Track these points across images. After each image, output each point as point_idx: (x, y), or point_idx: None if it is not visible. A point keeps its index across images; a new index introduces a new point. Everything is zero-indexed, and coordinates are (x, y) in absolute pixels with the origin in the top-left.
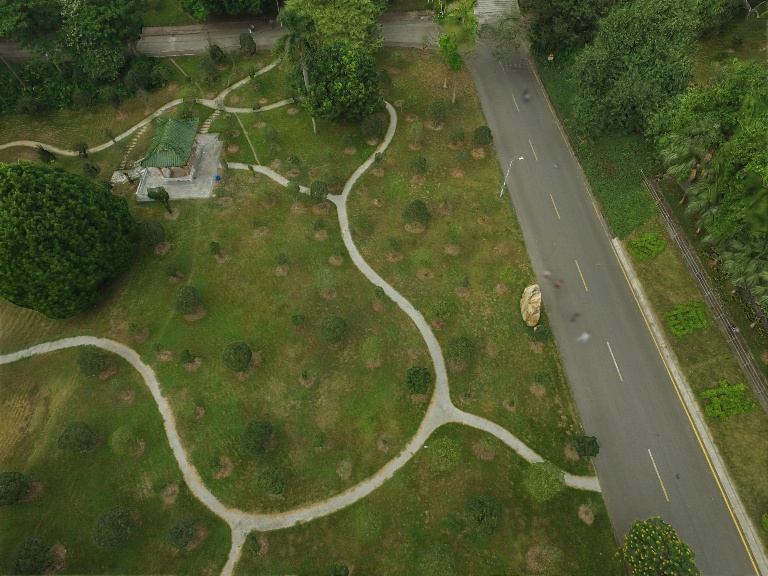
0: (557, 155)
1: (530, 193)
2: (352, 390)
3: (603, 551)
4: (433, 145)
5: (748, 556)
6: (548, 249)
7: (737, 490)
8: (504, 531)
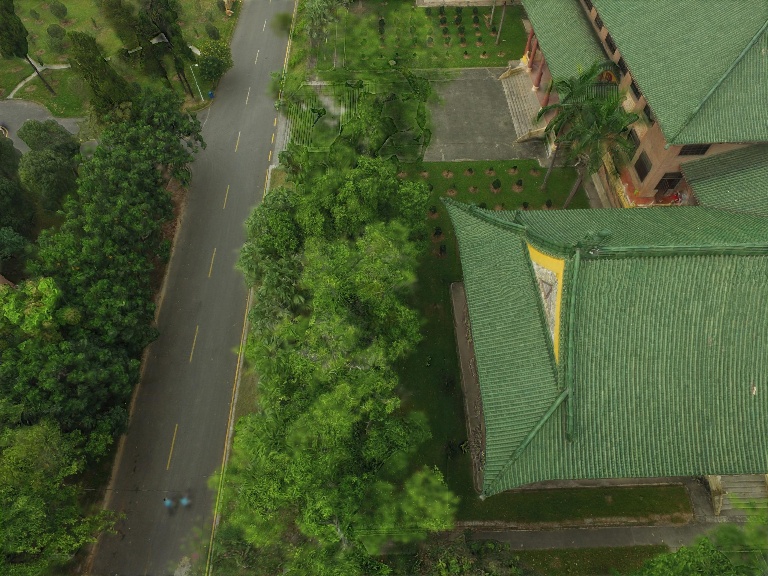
0: None
1: None
2: (119, 31)
3: None
4: None
5: None
6: None
7: (288, 58)
8: (168, 70)
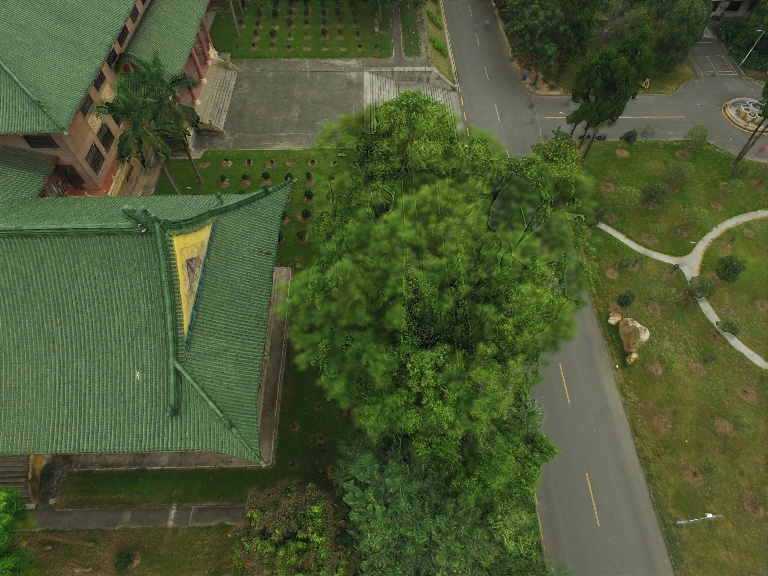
0: None
1: (630, 531)
2: None
3: (568, 187)
4: None
5: None
6: (603, 423)
7: None
8: None
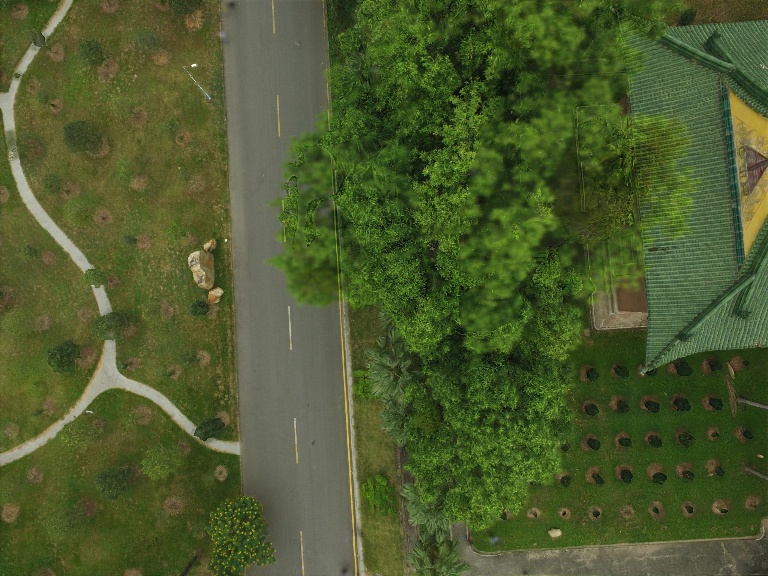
0: (304, 23)
1: (252, 93)
2: (19, 355)
3: None
4: (135, 2)
5: (350, 507)
6: (254, 183)
7: (356, 459)
8: (148, 484)
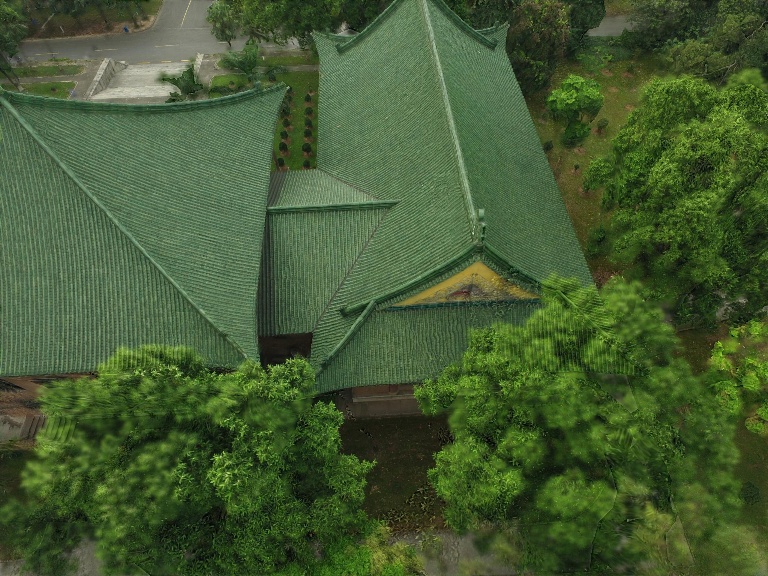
0: None
1: None
2: None
3: None
4: None
5: None
6: None
7: None
8: None
